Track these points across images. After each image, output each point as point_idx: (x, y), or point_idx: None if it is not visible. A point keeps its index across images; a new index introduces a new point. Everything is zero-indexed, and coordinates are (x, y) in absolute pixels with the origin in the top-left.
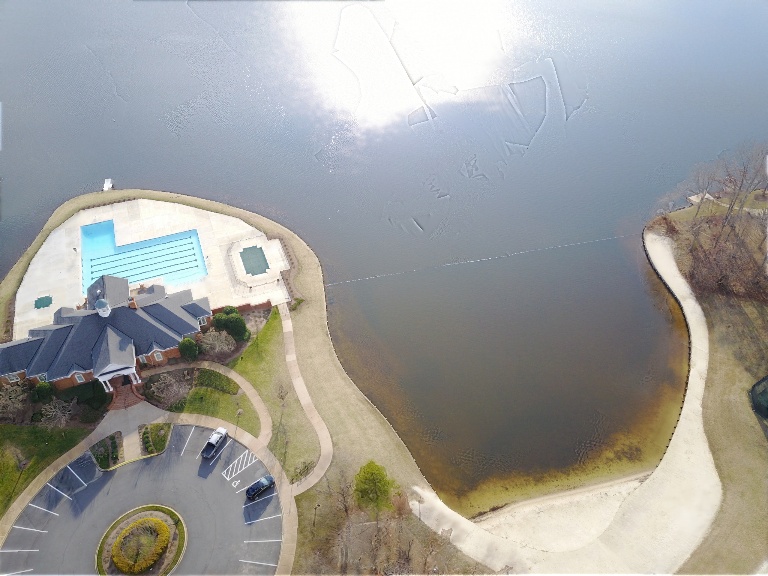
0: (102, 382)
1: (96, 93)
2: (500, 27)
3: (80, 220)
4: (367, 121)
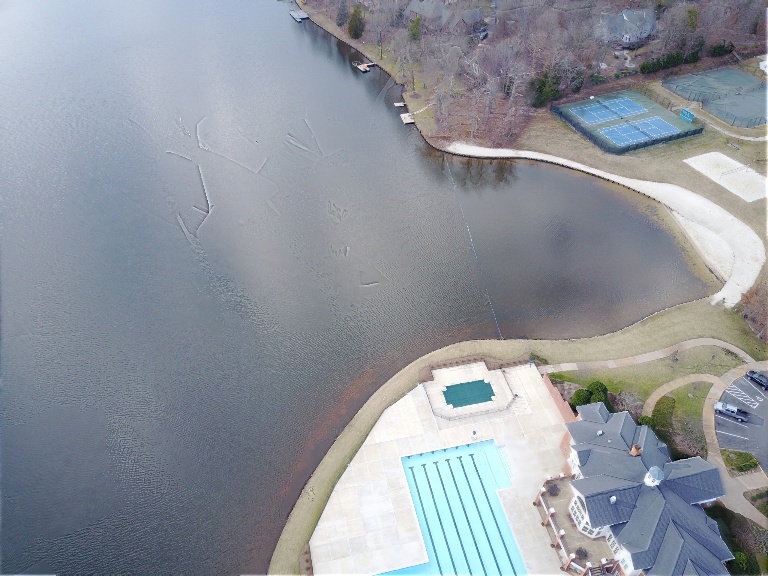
0: None
1: None
2: (114, 120)
3: None
4: (227, 266)
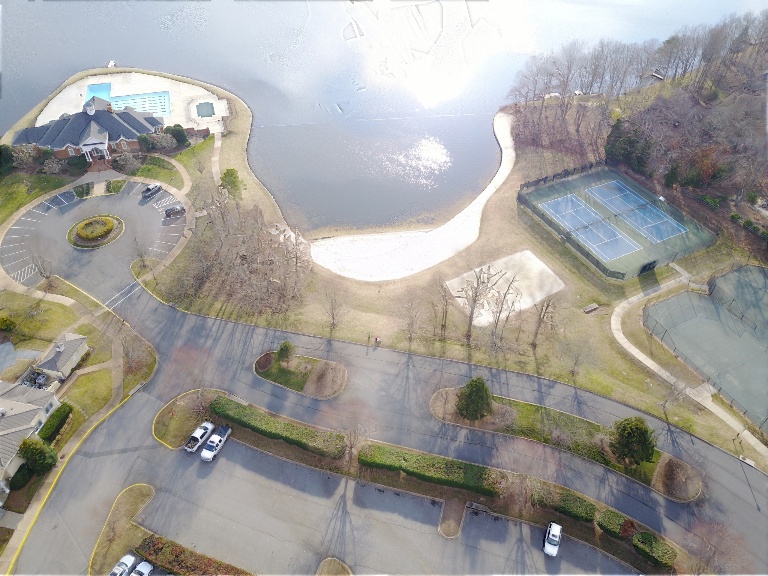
0: (85, 152)
1: (110, 1)
2: None
3: (88, 81)
4: (312, 34)
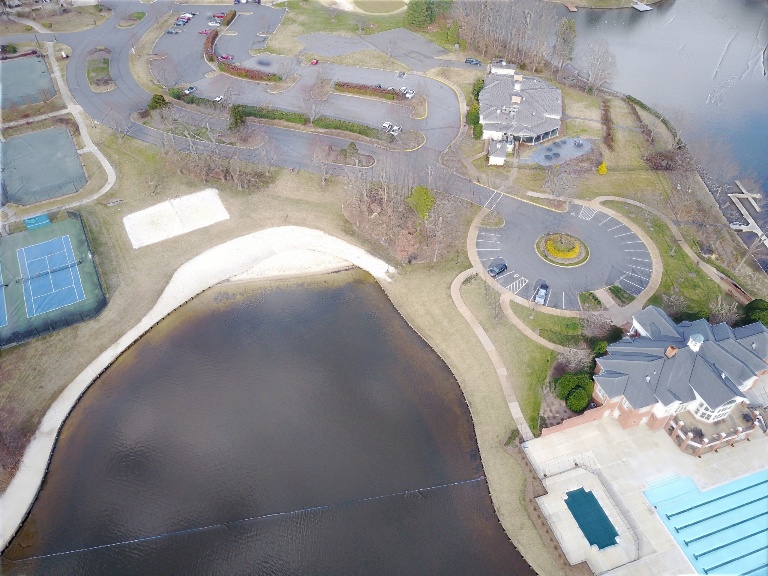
0: None
1: None
2: None
3: None
4: None
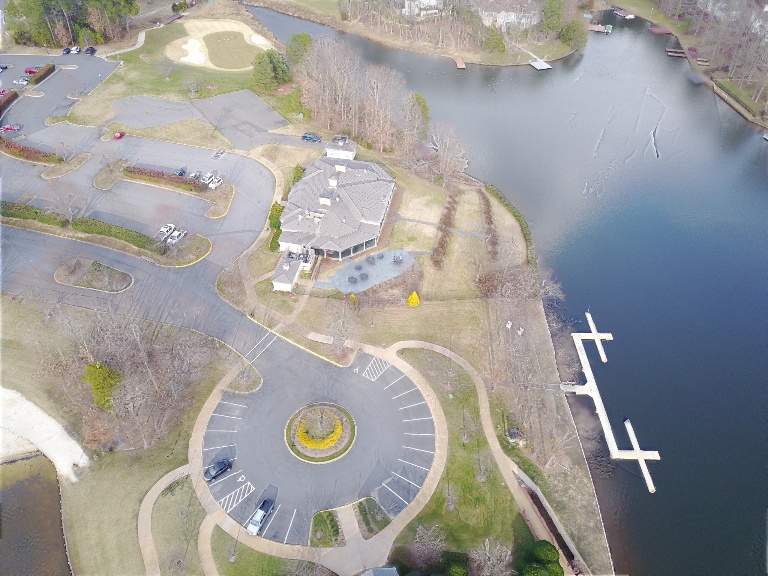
0: None
1: None
2: None
3: None
4: None
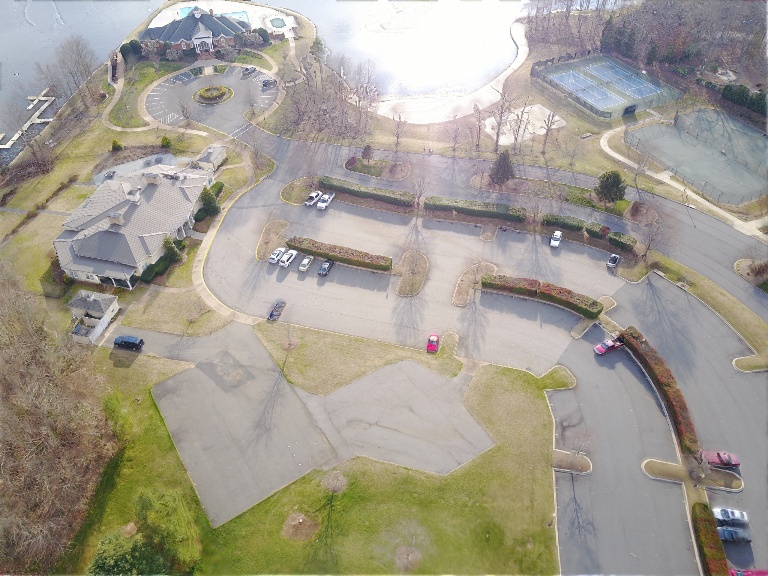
0: (195, 45)
1: None
2: None
3: (179, 6)
4: None
